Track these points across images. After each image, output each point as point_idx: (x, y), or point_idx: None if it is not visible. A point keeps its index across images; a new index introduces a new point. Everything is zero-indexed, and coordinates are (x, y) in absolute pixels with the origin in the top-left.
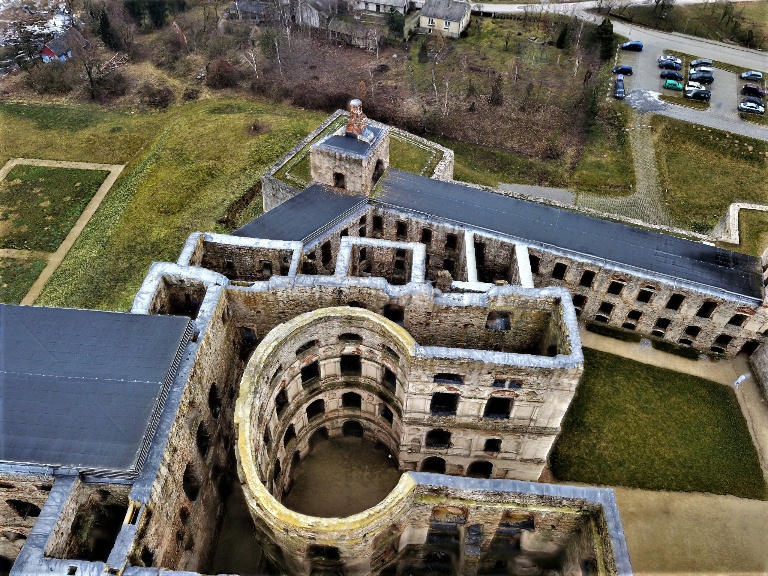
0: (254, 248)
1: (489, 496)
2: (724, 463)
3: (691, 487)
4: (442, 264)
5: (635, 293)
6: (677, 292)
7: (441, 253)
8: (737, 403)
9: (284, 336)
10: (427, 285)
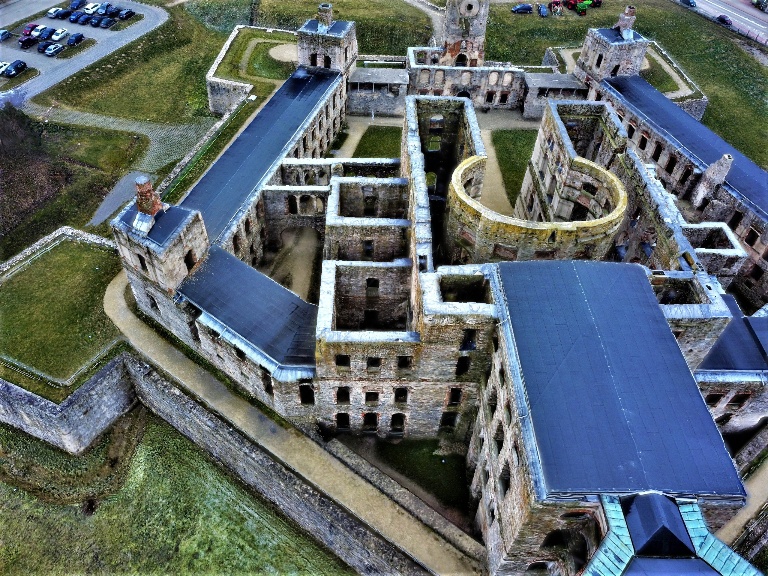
0: None
1: None
2: None
3: None
4: (260, 239)
5: None
6: None
7: (258, 229)
8: (382, 126)
9: None
10: (414, 152)
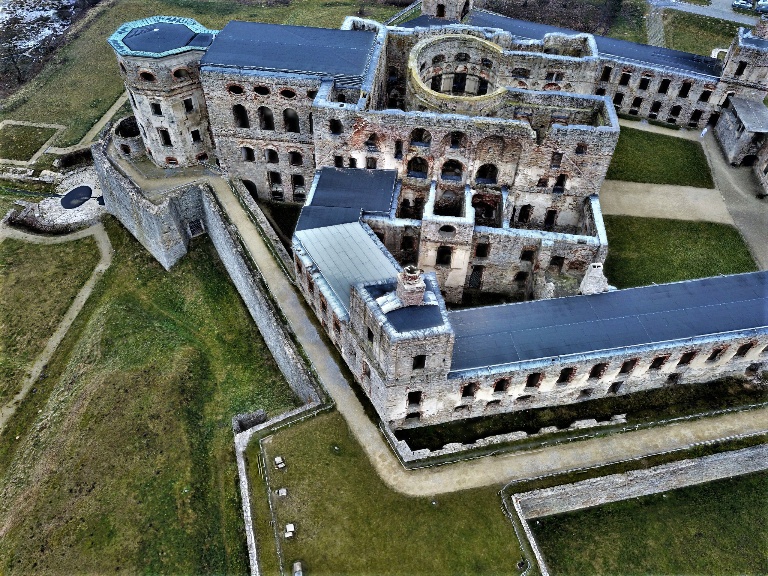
0: (394, 31)
1: (545, 100)
2: (688, 173)
3: (665, 182)
4: None
5: (638, 81)
6: (665, 77)
7: None
8: (702, 149)
9: (430, 42)
10: None
